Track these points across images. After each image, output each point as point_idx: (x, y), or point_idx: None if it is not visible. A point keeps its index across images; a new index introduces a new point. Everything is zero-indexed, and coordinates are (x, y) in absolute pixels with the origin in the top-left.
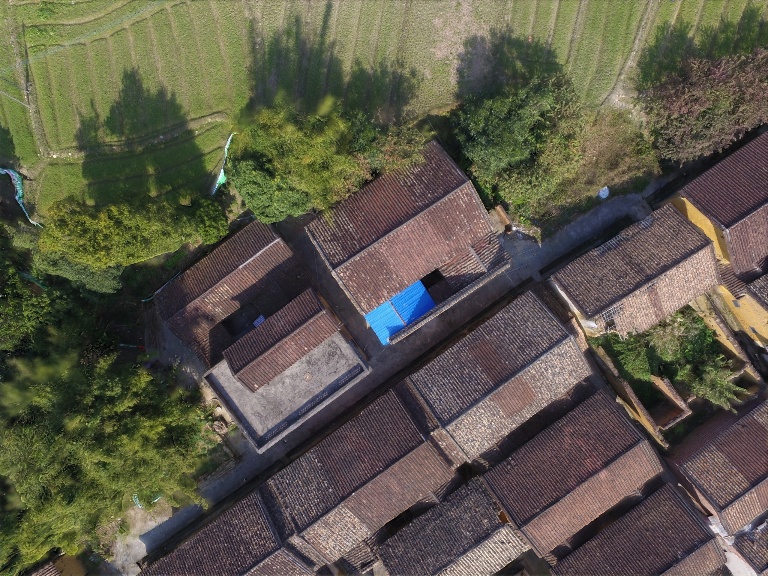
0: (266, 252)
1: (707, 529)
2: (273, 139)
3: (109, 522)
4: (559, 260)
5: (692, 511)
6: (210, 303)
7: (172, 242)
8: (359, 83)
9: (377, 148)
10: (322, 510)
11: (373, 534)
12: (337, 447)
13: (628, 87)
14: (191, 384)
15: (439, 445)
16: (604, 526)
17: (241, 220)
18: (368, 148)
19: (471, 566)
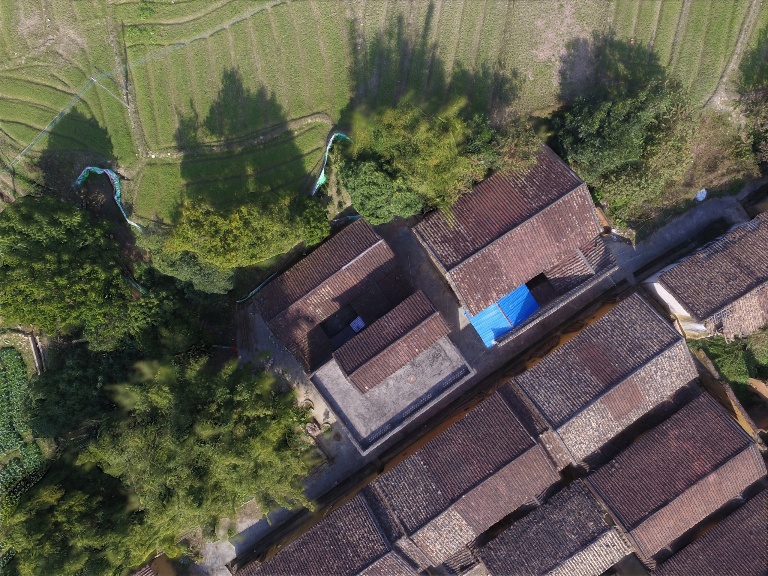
0: (369, 253)
1: None
2: (397, 140)
3: None
4: (653, 262)
5: None
6: (311, 304)
7: (288, 243)
8: (461, 84)
9: (494, 149)
10: (432, 513)
11: None
12: (443, 449)
13: (730, 90)
14: (283, 385)
15: (546, 447)
16: (704, 529)
17: (338, 221)
18: (484, 149)
19: (575, 569)
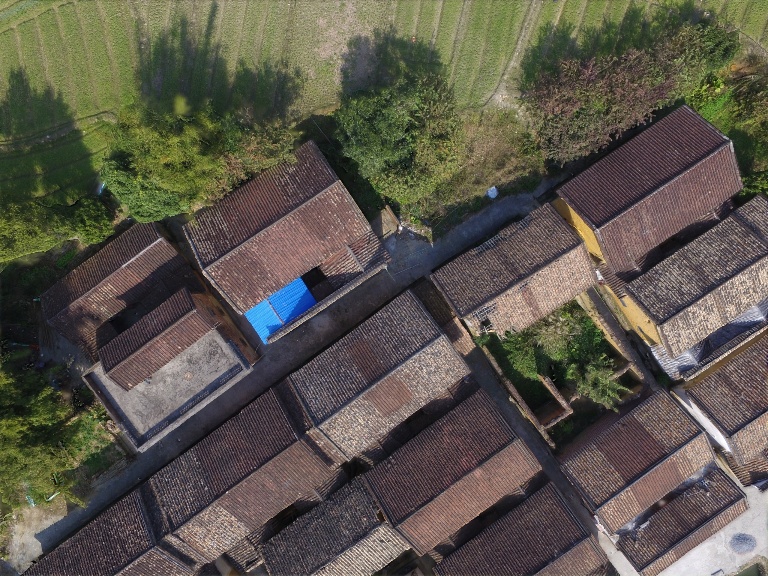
0: (149, 251)
1: (583, 528)
2: (133, 139)
3: (1, 521)
4: (451, 260)
5: (571, 510)
6: (94, 302)
7: (40, 241)
8: (244, 83)
9: None
10: (196, 508)
11: (258, 533)
12: (216, 446)
13: (511, 87)
14: None
15: (317, 444)
16: (488, 525)
17: (131, 220)
18: (237, 148)
19: (351, 564)
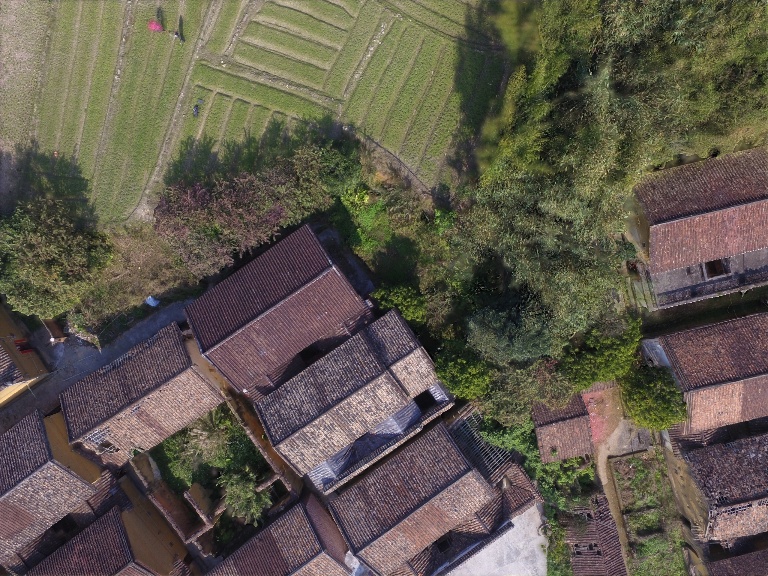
0: None
1: None
2: None
3: None
4: None
5: None
6: None
7: None
8: None
9: None
10: None
11: None
12: None
13: (154, 201)
14: None
15: None
16: None
17: None
18: None
19: None
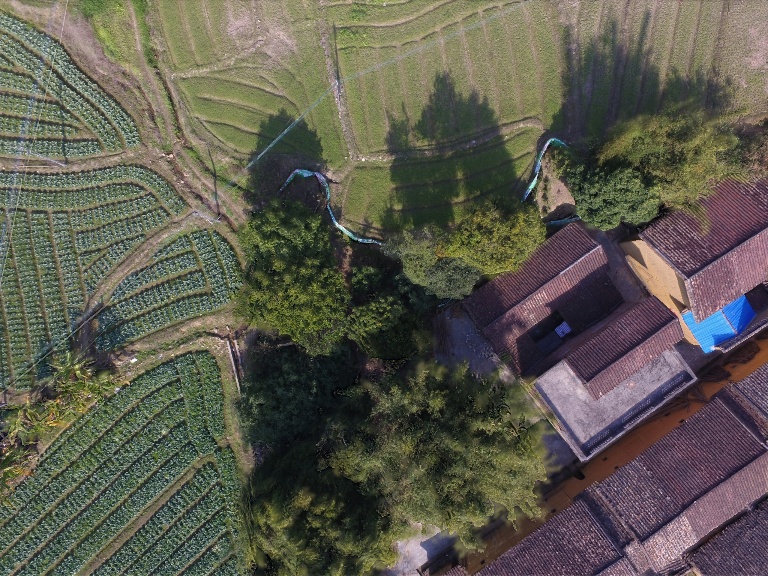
0: (585, 259)
1: None
2: (658, 147)
3: None
4: None
5: None
6: (527, 309)
7: None
8: (675, 90)
9: (739, 157)
10: (663, 518)
11: None
12: (666, 455)
13: None
14: (480, 390)
15: None
16: None
17: None
18: (727, 157)
19: None
